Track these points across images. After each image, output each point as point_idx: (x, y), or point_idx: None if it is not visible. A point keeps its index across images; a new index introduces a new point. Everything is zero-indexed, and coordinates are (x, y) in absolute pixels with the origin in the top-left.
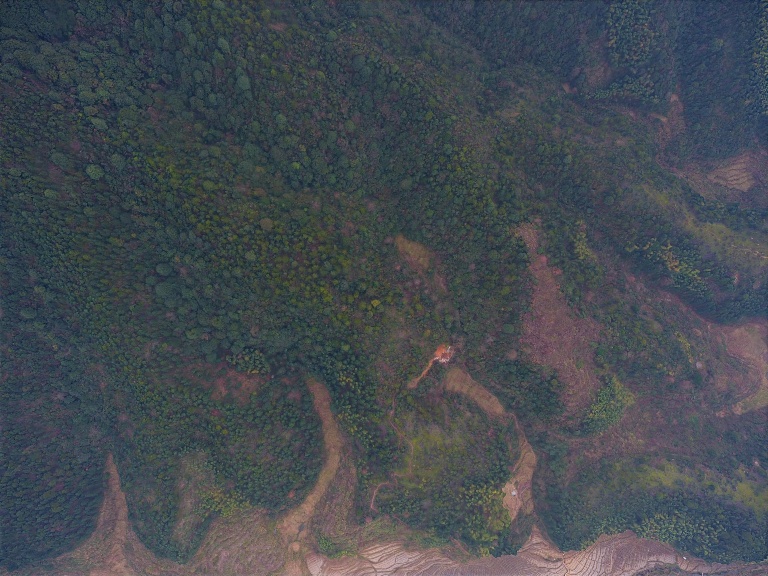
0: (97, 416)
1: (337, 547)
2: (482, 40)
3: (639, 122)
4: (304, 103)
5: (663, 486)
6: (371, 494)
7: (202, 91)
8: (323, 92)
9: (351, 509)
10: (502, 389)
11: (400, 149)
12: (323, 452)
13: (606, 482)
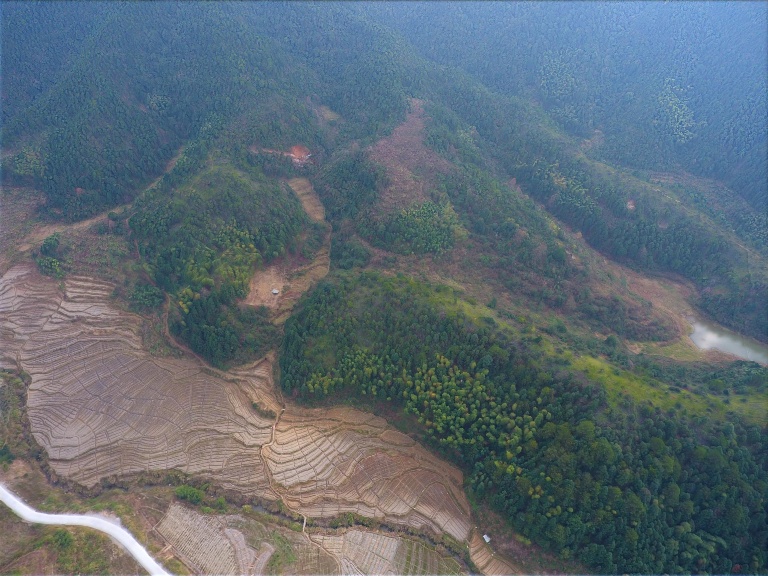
0: None
1: (57, 253)
2: None
3: None
4: None
5: (463, 312)
6: None
7: (264, 1)
8: None
9: None
10: None
11: None
12: (141, 189)
13: None
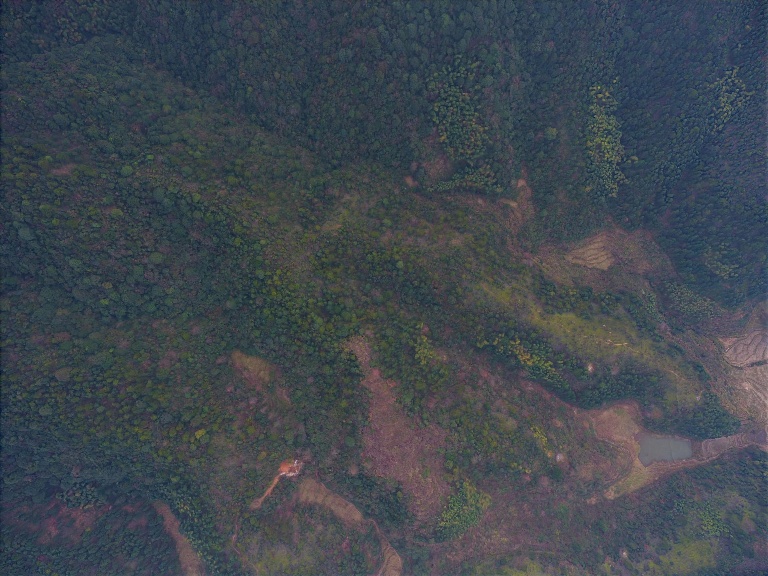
0: None
1: None
2: (314, 141)
3: (486, 211)
4: (99, 244)
5: None
6: None
7: None
8: (121, 229)
9: None
10: (354, 499)
11: (219, 271)
12: (178, 572)
13: None
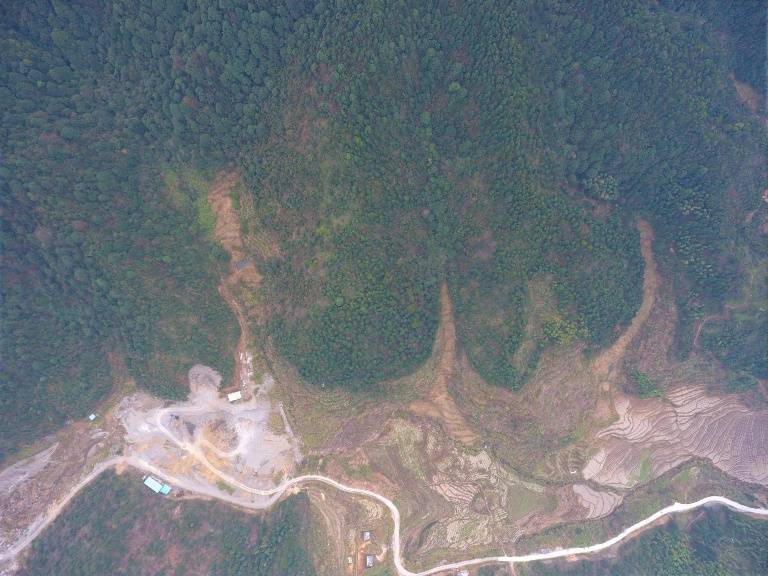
0: (444, 241)
1: (650, 385)
2: None
3: None
4: None
5: None
6: (696, 329)
7: None
8: None
9: (672, 345)
10: None
11: None
12: None
13: None
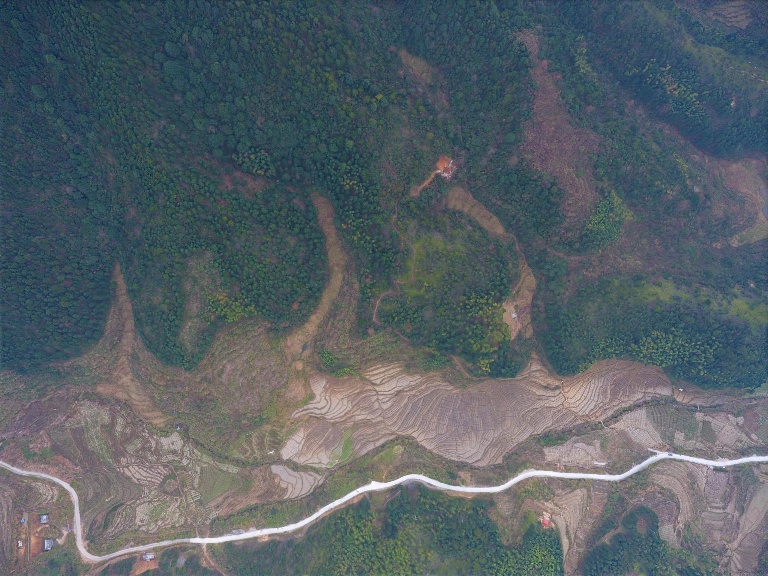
0: (105, 219)
1: (340, 364)
2: None
3: None
4: None
5: (660, 300)
6: (374, 305)
7: None
8: None
9: (354, 322)
10: (503, 205)
11: None
12: (326, 268)
13: (604, 296)
